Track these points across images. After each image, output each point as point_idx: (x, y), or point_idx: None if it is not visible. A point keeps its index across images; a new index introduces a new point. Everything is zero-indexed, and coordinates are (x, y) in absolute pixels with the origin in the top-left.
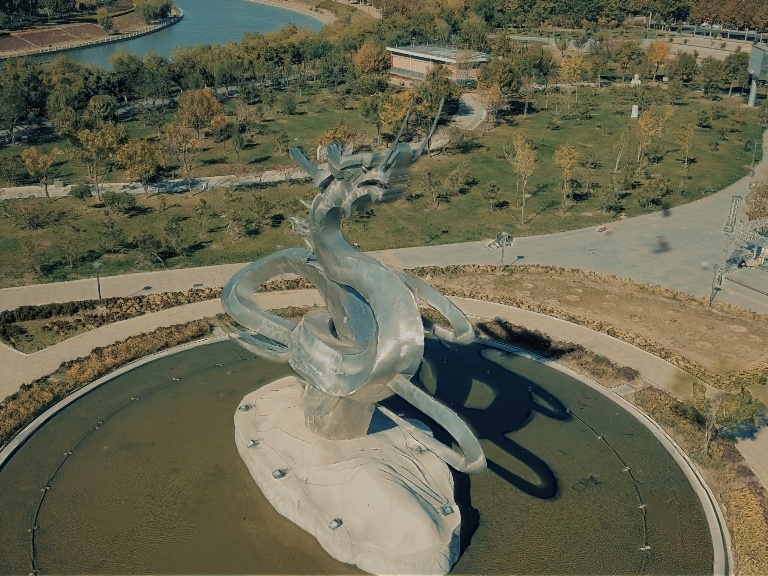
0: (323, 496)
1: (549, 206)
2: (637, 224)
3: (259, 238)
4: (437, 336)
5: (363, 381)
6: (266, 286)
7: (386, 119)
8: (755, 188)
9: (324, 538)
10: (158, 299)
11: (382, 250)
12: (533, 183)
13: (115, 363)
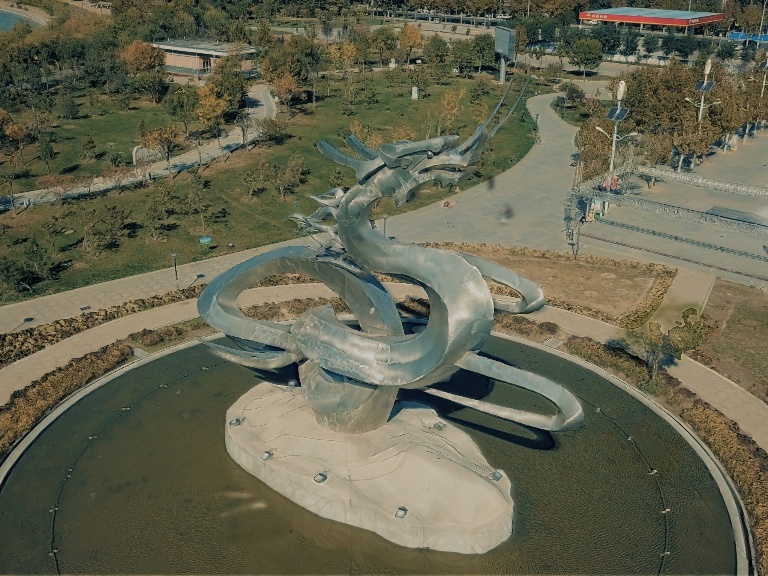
0: (374, 489)
1: None
2: (473, 195)
3: (122, 251)
4: (497, 309)
5: (433, 364)
6: (162, 299)
7: (204, 115)
8: (584, 152)
9: (389, 529)
10: (51, 329)
11: (258, 247)
12: None
13: (48, 404)
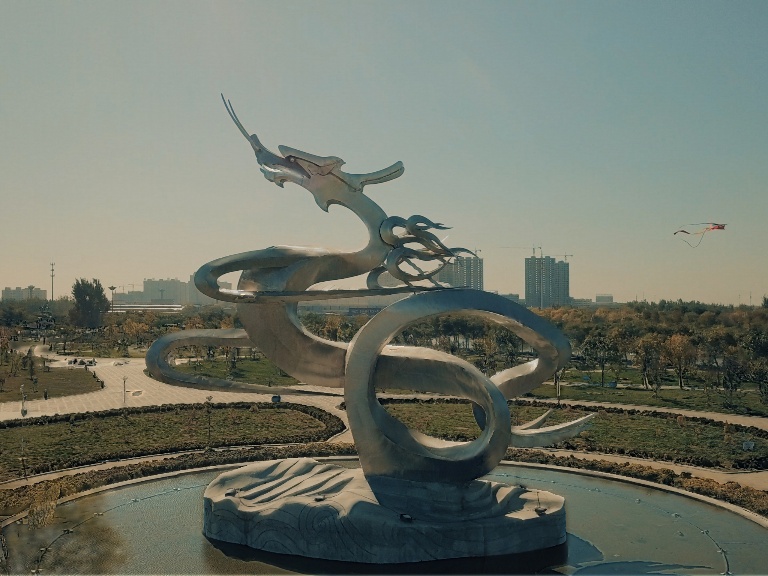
0: None
1: None
2: None
3: None
4: None
5: None
6: None
7: None
8: None
9: None
10: None
11: None
12: None
13: None
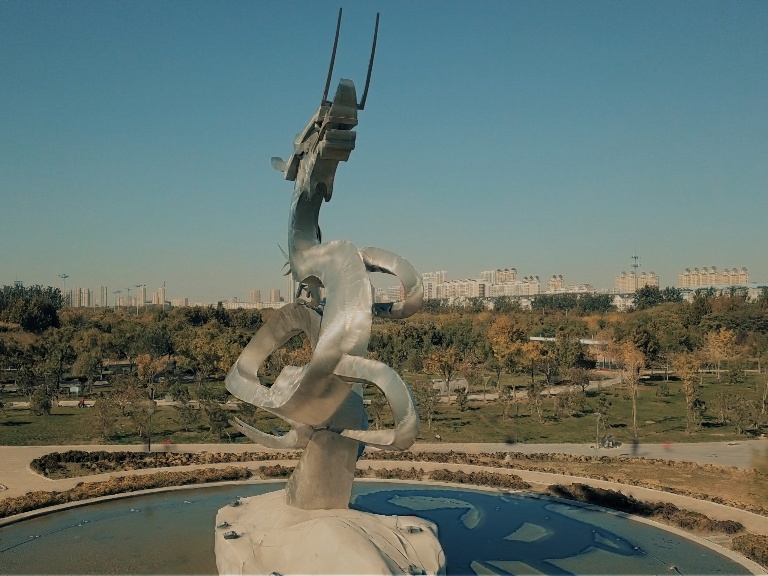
0: (273, 556)
1: (673, 429)
2: None
3: None
4: (392, 311)
5: None
6: None
7: (499, 352)
8: None
9: None
10: (208, 456)
11: (466, 443)
12: (660, 415)
13: (131, 485)
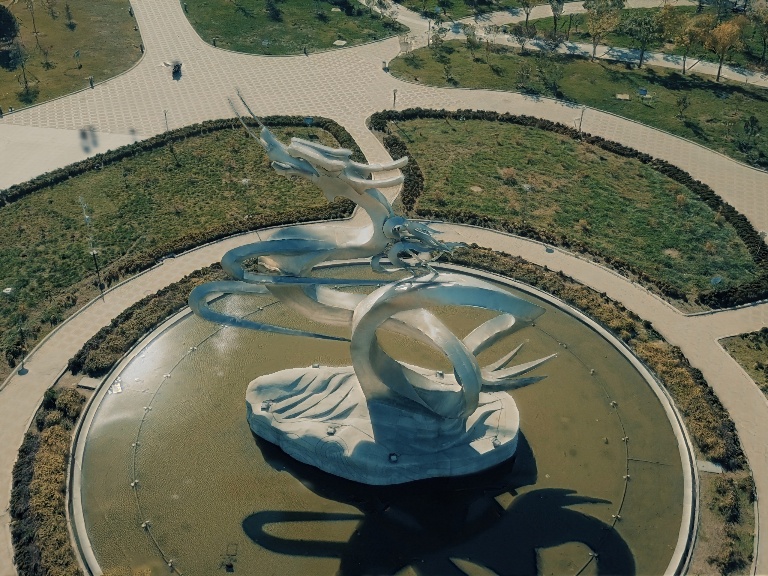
0: None
1: None
2: None
3: None
4: None
5: None
6: None
7: None
8: None
9: None
10: None
11: None
12: None
13: None
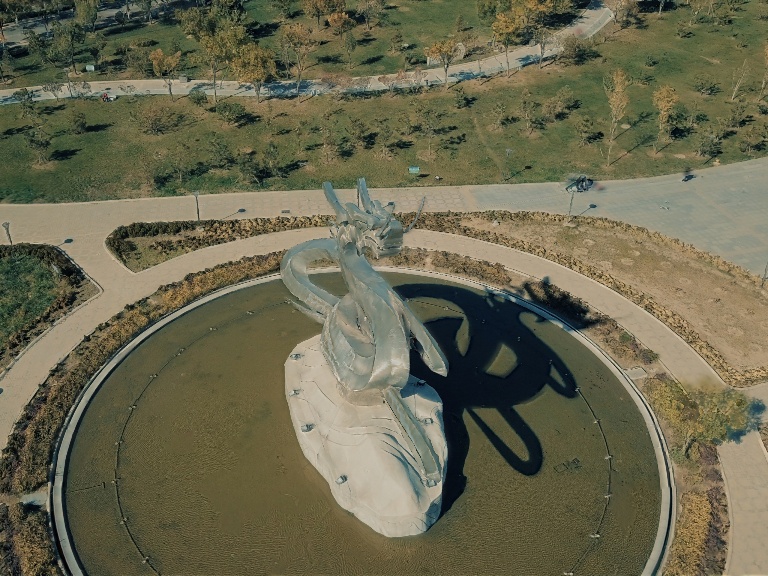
0: (337, 453)
1: (644, 142)
2: (728, 173)
3: (350, 161)
4: None
5: (363, 385)
6: None
7: (498, 30)
8: None
9: (333, 488)
10: (248, 225)
11: (461, 185)
12: (637, 110)
13: (202, 292)
